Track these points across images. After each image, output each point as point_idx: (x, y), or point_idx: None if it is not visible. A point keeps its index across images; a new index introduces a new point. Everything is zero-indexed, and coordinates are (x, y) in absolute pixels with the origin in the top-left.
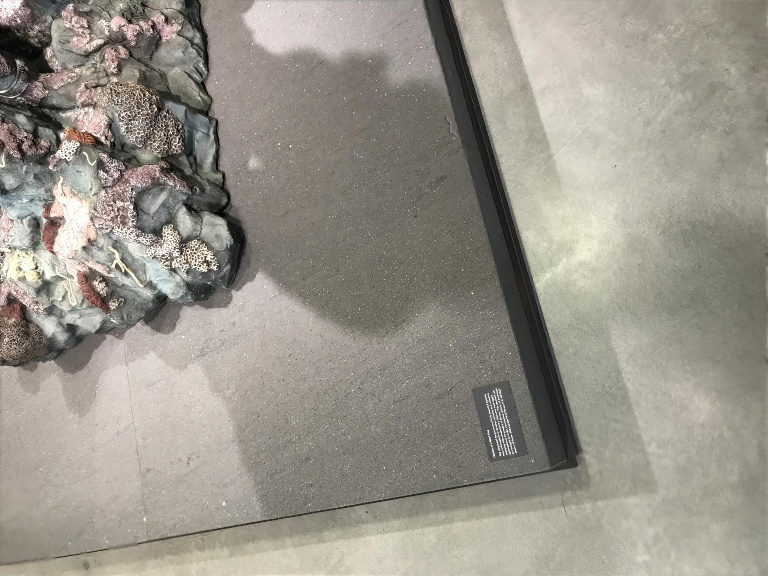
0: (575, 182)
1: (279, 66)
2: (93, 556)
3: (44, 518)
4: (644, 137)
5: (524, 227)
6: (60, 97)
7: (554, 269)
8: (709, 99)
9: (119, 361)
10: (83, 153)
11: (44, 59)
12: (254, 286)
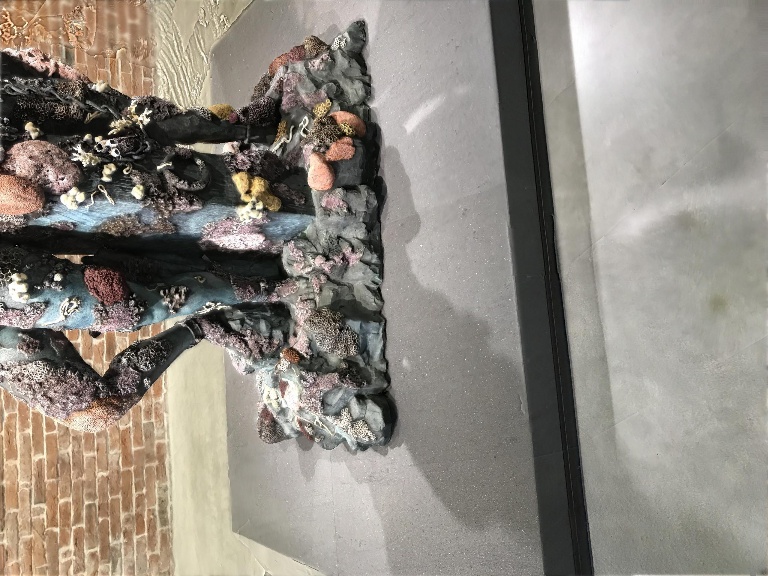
0: (627, 453)
1: (424, 298)
2: (311, 570)
3: (288, 533)
4: (682, 441)
5: (586, 471)
6: (287, 301)
7: (602, 513)
8: (734, 436)
9: (327, 457)
10: (292, 368)
11: (281, 261)
12: (400, 451)
